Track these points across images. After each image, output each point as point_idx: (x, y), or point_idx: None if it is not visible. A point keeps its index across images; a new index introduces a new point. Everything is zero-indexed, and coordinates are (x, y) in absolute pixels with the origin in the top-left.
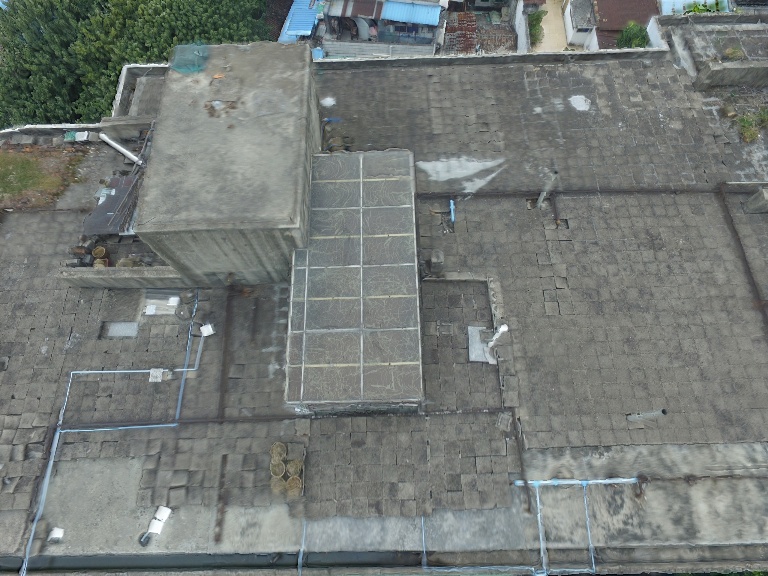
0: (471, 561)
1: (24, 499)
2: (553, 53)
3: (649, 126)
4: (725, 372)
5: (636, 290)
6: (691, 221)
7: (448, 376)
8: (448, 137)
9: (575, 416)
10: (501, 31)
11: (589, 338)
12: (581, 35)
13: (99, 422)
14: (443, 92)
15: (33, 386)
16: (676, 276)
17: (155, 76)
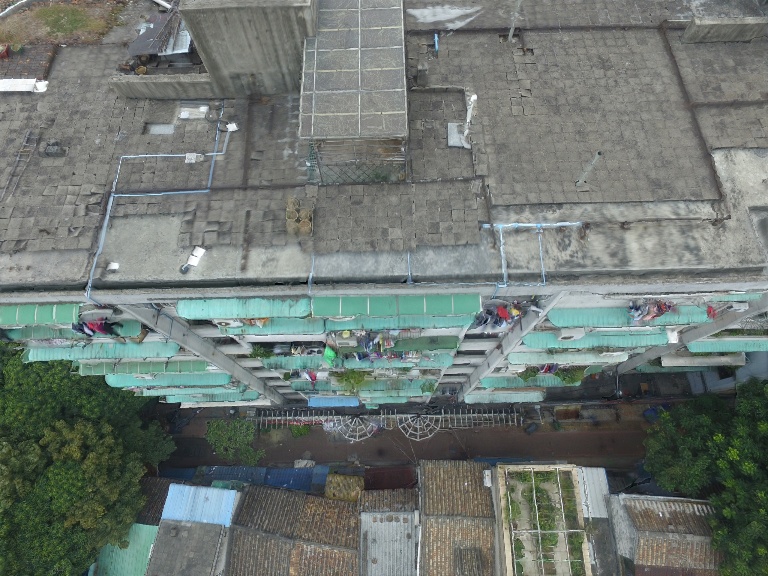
0: None
1: (87, 241)
2: None
3: None
4: (658, 153)
5: (588, 97)
6: (636, 49)
7: (431, 157)
8: None
9: (534, 183)
10: None
11: (547, 131)
12: None
13: (145, 189)
14: None
15: (90, 166)
16: (621, 87)
17: None
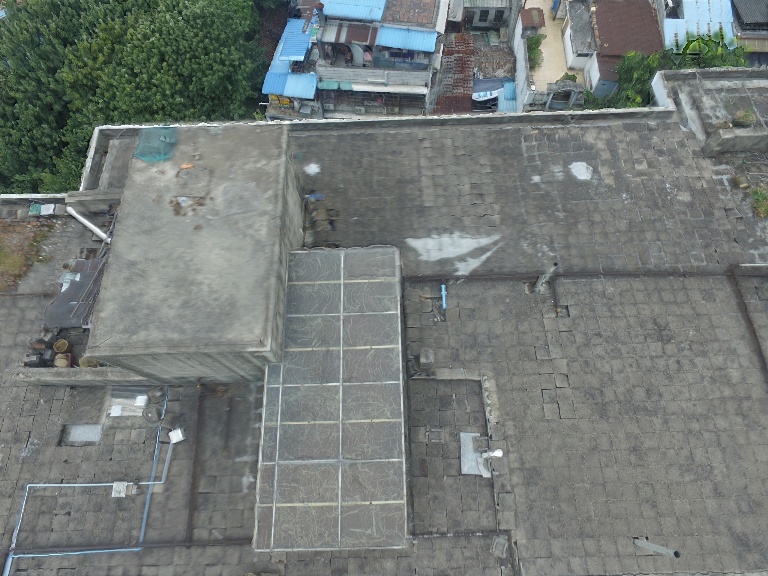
0: None
1: None
2: (552, 113)
3: (655, 198)
4: (741, 487)
5: (643, 390)
6: (702, 308)
7: (438, 491)
8: (440, 210)
9: (577, 540)
10: (499, 53)
11: (592, 446)
12: (581, 59)
13: (55, 546)
14: (435, 158)
15: None
16: (686, 373)
17: (129, 137)
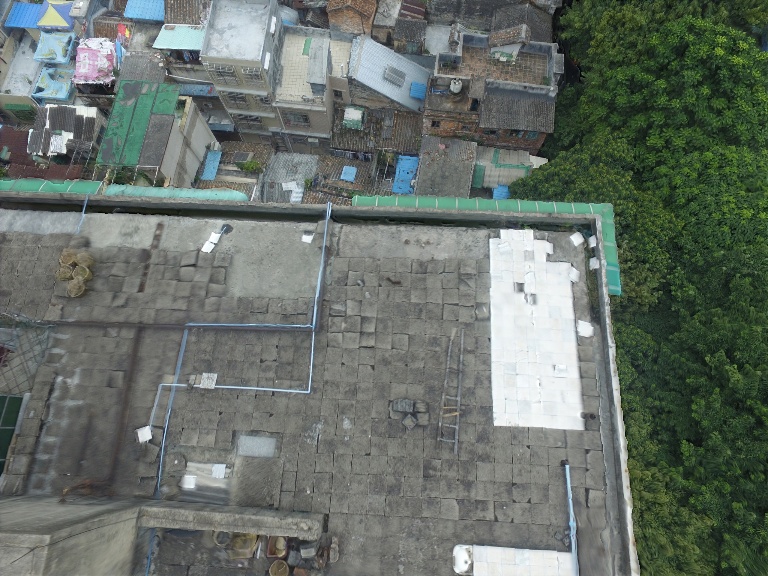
0: None
1: (339, 266)
2: None
3: None
4: None
5: None
6: None
7: None
8: None
9: None
10: None
11: None
12: None
13: (269, 332)
14: None
15: (352, 379)
16: None
17: None
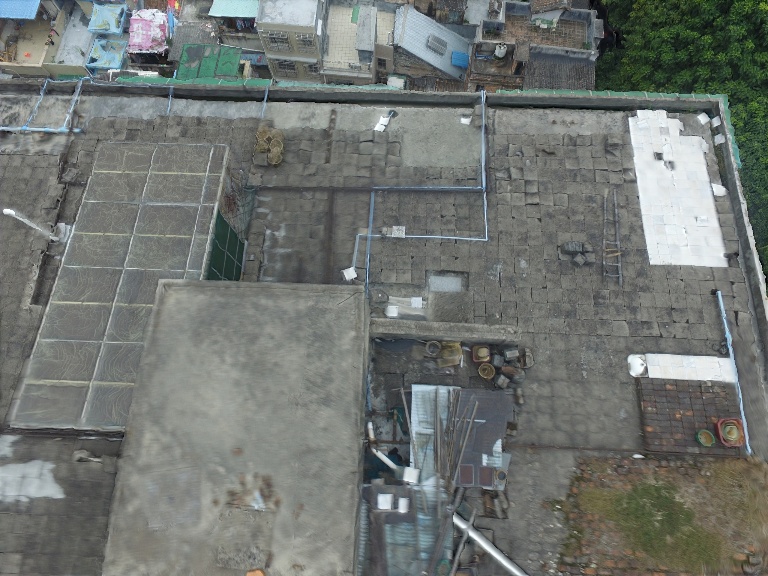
0: (141, 96)
1: (499, 140)
2: None
3: None
4: None
5: None
6: None
7: None
8: (1, 545)
9: (8, 177)
10: None
11: None
12: None
13: (446, 193)
14: None
15: (523, 229)
16: None
17: None
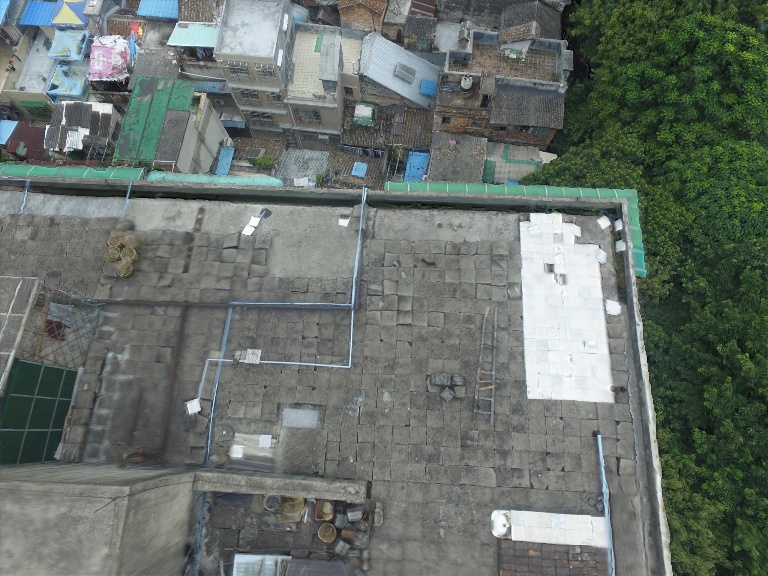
0: None
1: (375, 248)
2: None
3: None
4: None
5: None
6: None
7: None
8: None
9: None
10: None
11: None
12: None
13: (310, 310)
14: None
15: (391, 354)
16: None
17: None
